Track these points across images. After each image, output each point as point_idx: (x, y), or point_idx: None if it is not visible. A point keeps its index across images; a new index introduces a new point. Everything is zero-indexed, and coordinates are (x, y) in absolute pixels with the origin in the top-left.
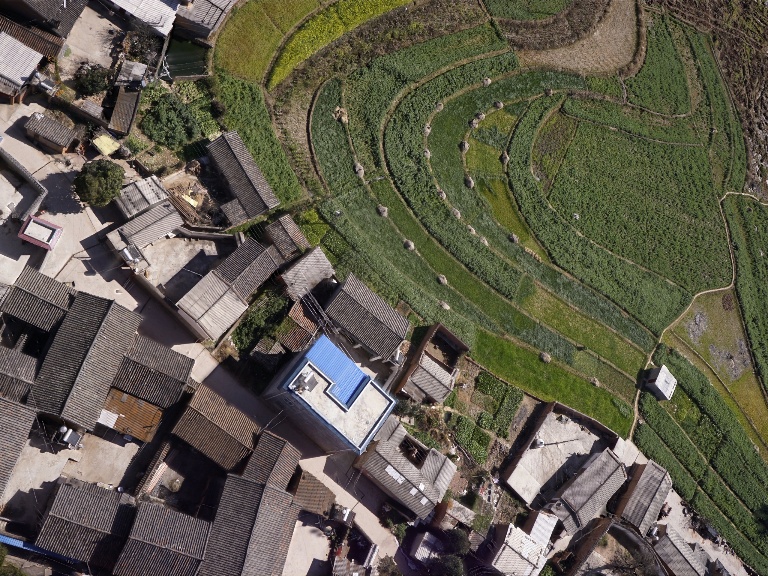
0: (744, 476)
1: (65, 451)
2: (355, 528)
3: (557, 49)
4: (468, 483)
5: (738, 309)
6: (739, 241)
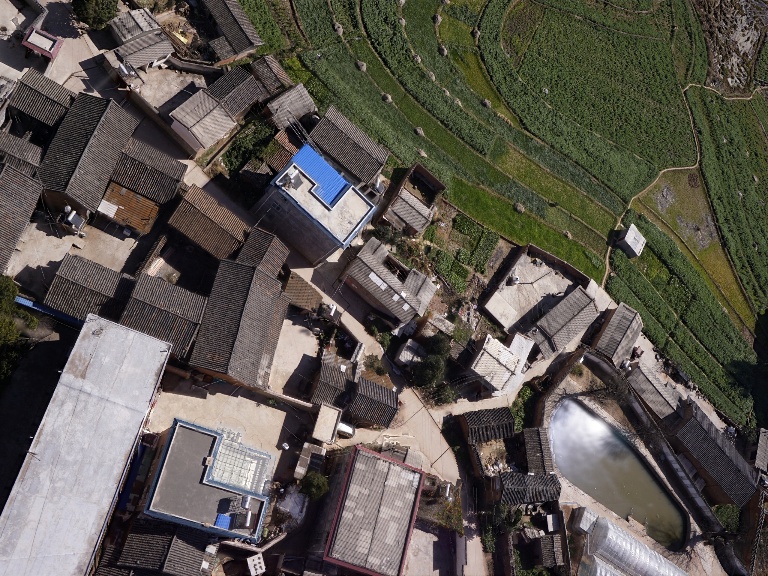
0: (714, 333)
1: (69, 237)
2: (342, 329)
3: None
4: (448, 307)
5: (703, 187)
6: (702, 127)
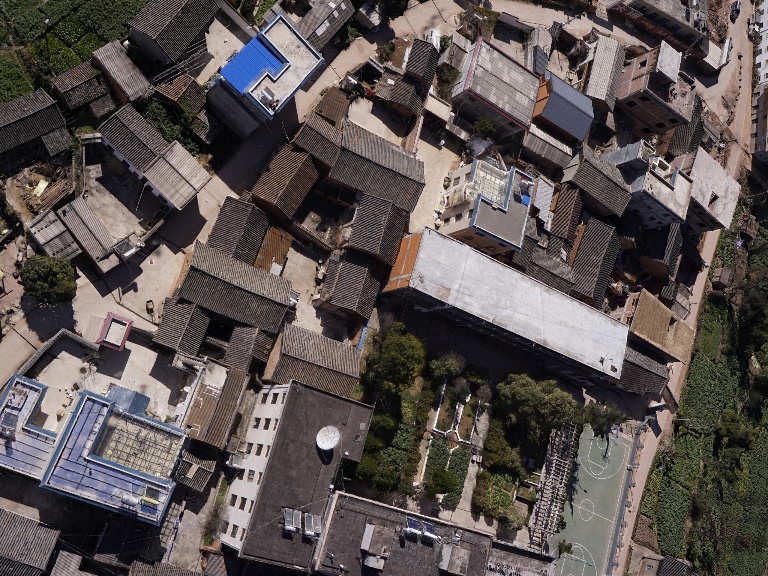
0: None
1: None
2: None
3: None
4: None
5: None
6: None
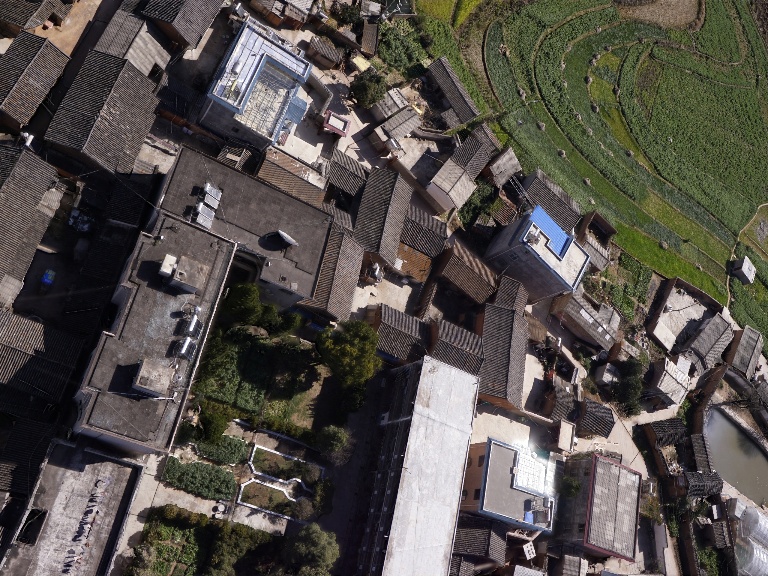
0: None
1: (368, 287)
2: (561, 356)
3: (643, 6)
4: (625, 334)
5: None
6: None
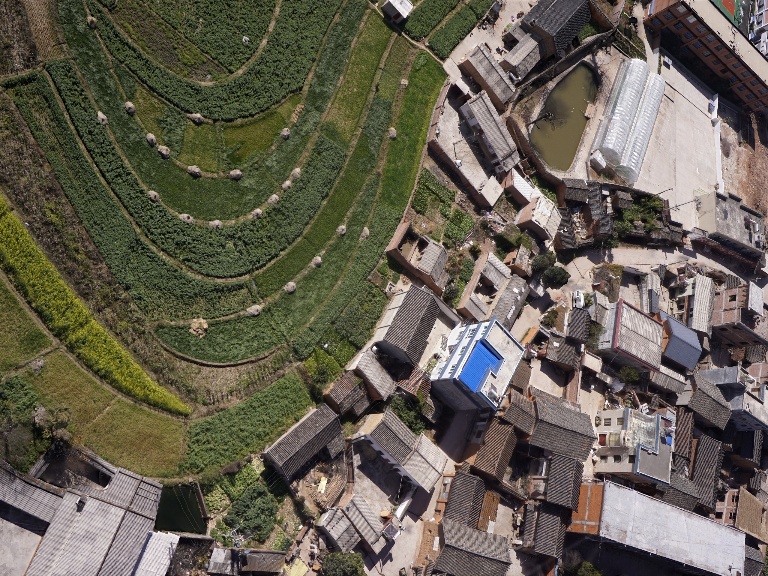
0: None
1: None
2: None
3: None
4: (488, 238)
5: None
6: None
